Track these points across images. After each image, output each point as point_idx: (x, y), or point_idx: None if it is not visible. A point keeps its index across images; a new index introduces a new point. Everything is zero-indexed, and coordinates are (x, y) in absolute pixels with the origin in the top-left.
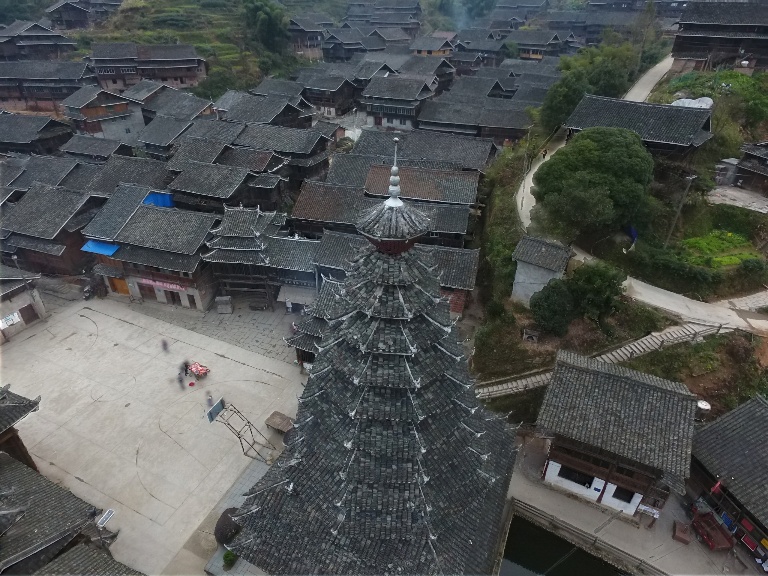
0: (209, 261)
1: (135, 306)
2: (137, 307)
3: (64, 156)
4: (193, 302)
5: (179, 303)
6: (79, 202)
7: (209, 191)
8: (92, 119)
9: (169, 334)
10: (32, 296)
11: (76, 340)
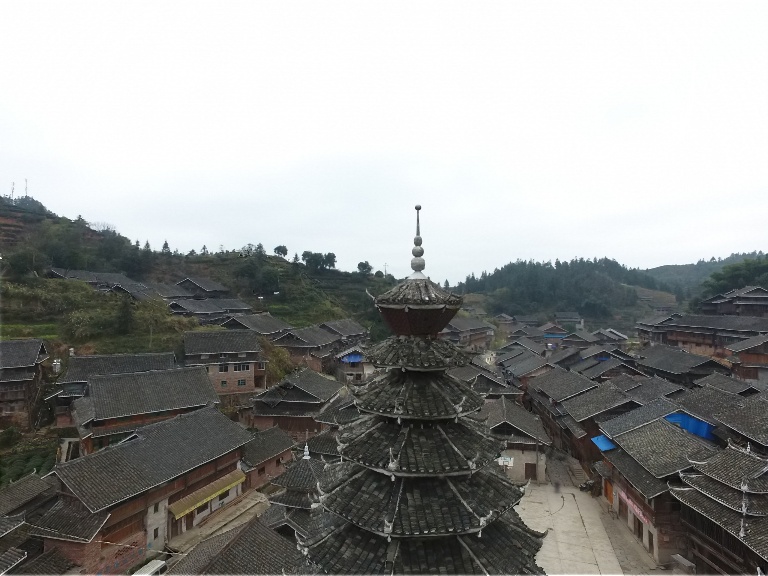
0: (675, 497)
1: (607, 517)
2: (607, 519)
3: (694, 388)
4: (652, 544)
5: (642, 539)
6: (618, 402)
7: (752, 432)
8: (748, 364)
9: (598, 555)
10: (537, 457)
11: (535, 507)
